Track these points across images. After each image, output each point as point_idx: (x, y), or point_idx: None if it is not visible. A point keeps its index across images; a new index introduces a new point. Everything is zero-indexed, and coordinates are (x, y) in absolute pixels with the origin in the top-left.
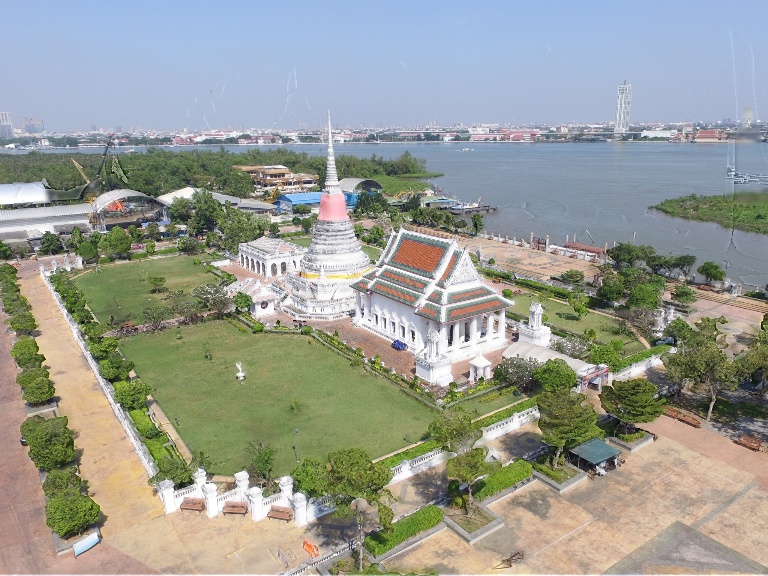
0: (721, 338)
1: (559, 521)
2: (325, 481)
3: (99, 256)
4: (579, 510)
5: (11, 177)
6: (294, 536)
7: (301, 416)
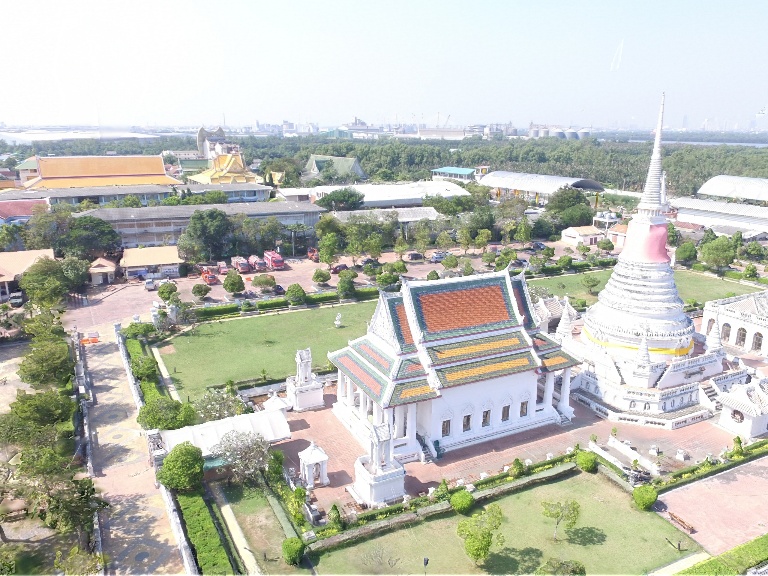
0: (83, 571)
1: (7, 402)
2: (127, 331)
3: (700, 262)
4: (5, 411)
5: (758, 173)
6: (110, 339)
7: (255, 344)
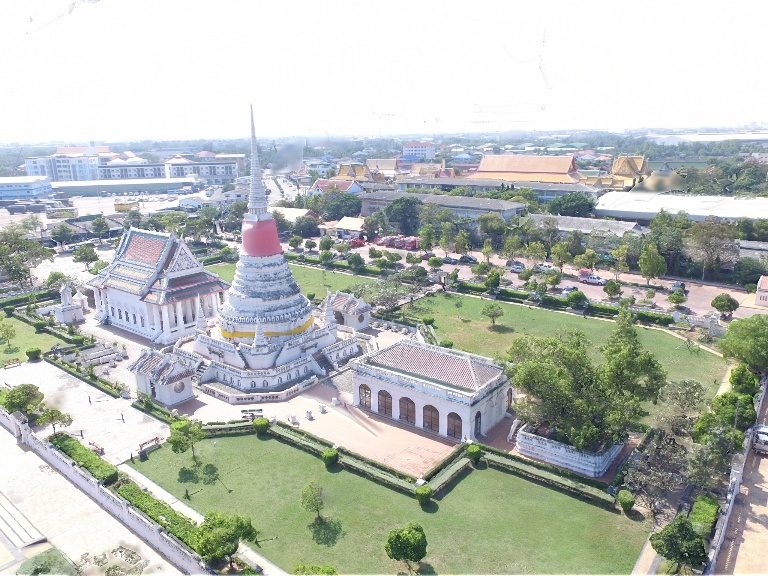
0: None
1: None
2: None
3: None
4: None
5: None
6: None
7: None
